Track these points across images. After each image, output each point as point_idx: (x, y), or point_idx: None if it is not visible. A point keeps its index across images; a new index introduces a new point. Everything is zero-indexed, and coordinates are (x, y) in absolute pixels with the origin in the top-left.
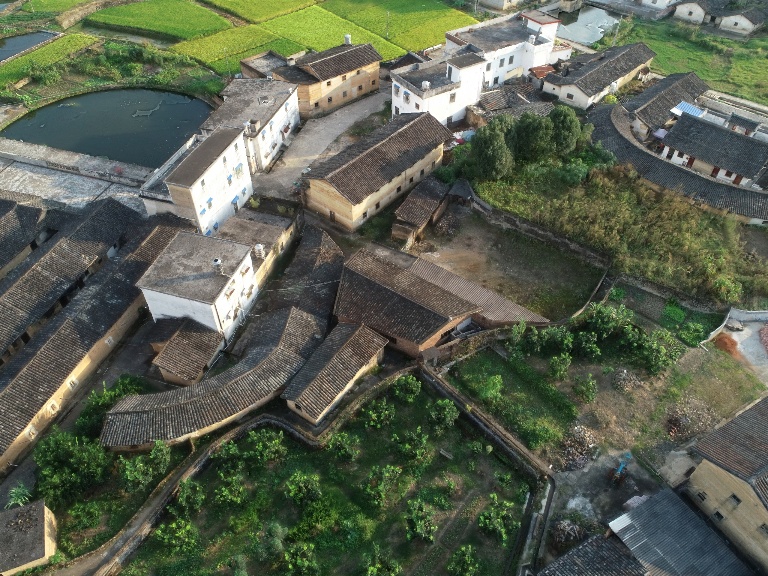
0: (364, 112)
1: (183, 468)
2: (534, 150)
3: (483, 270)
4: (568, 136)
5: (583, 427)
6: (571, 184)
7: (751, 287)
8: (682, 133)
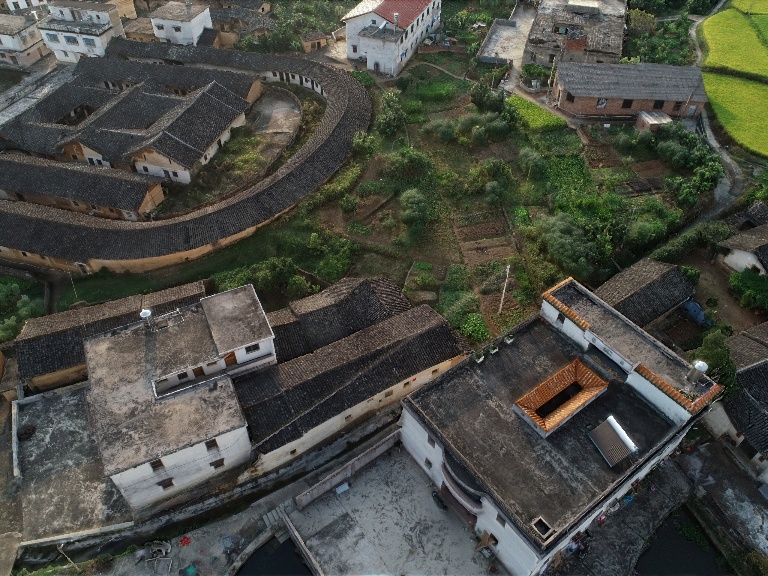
0: None
1: None
2: None
3: None
4: None
5: None
6: None
7: None
8: None
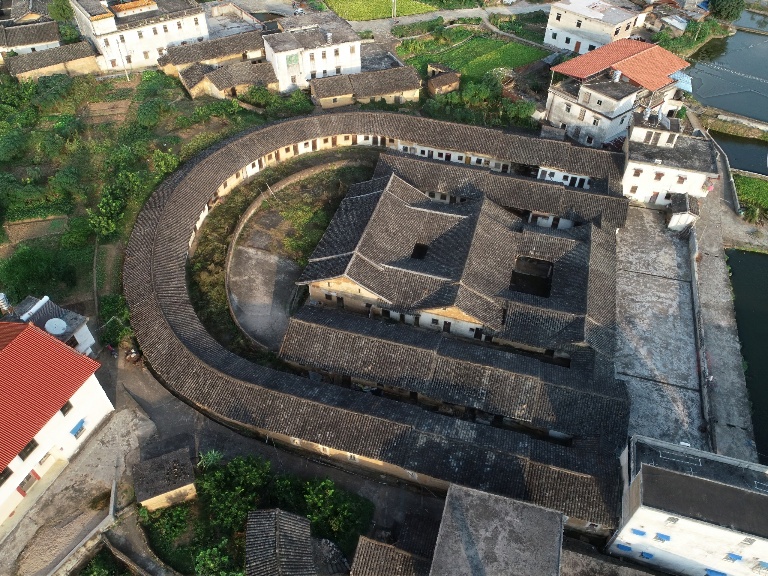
0: None
1: None
2: None
3: None
4: None
5: None
6: None
7: None
8: None
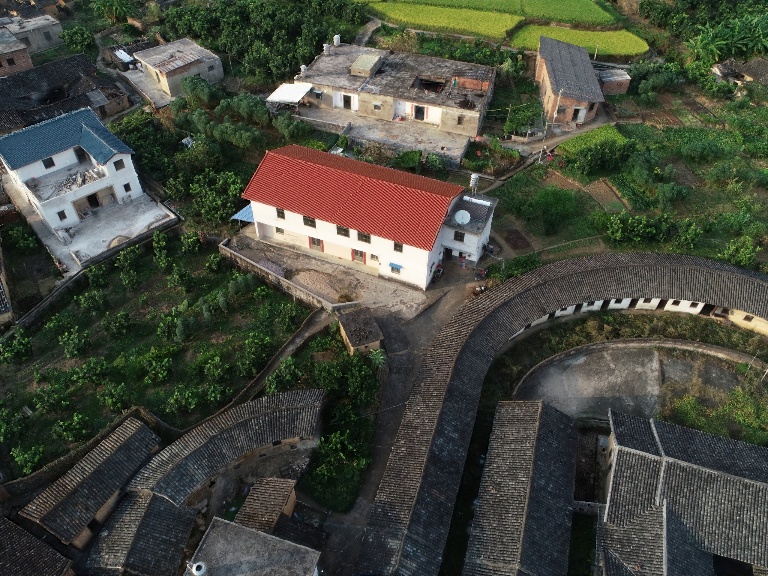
0: None
1: None
2: None
3: None
4: None
5: None
6: None
7: None
8: None
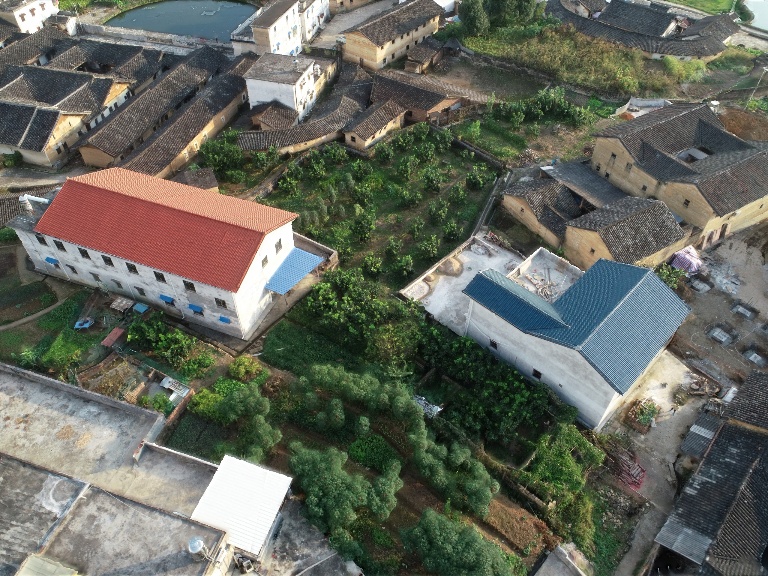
0: (377, 10)
1: (287, 164)
2: (504, 20)
3: (468, 88)
4: (527, 6)
5: (531, 150)
6: (529, 38)
7: (645, 85)
8: (612, 11)
